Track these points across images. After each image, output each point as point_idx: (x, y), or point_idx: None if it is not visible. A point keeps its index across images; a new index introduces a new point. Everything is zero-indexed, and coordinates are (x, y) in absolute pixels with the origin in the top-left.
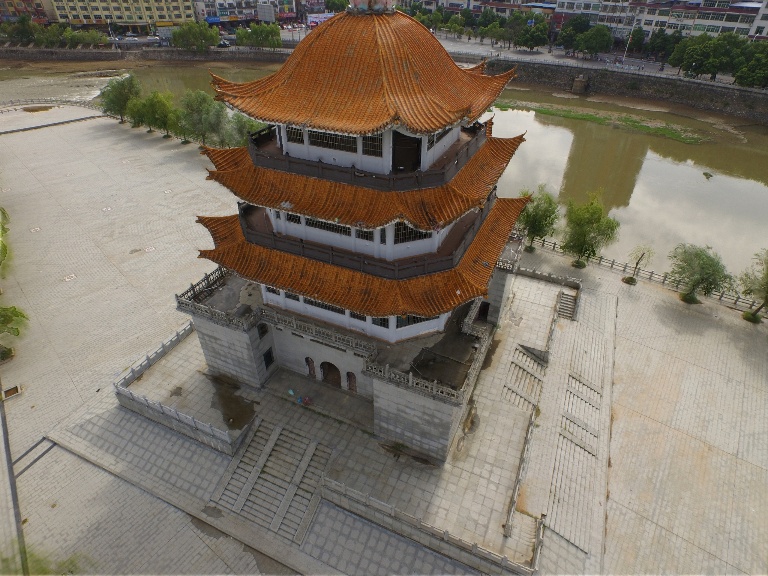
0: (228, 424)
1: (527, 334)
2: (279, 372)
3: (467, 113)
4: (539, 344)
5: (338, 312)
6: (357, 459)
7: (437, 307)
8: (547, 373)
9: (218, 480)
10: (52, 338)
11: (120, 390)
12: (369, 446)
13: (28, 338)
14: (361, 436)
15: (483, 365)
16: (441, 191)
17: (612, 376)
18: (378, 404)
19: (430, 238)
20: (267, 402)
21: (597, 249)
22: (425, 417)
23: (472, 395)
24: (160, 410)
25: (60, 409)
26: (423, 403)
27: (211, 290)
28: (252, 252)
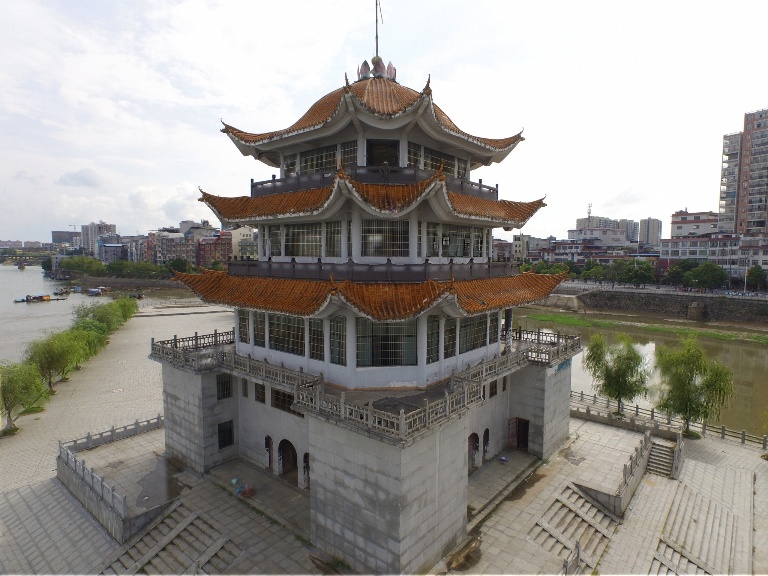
0: (139, 500)
1: (588, 474)
2: (236, 462)
3: (425, 90)
4: (606, 486)
5: (299, 354)
6: (267, 568)
7: (393, 313)
8: (620, 531)
9: (85, 574)
10: (60, 426)
11: (62, 452)
12: (294, 556)
13: (41, 424)
14: (291, 542)
15: (510, 496)
16: (410, 188)
17: (750, 565)
18: (314, 475)
19: (407, 257)
20: (201, 488)
21: (713, 415)
22: (367, 491)
23: (480, 525)
24: (82, 475)
25: (6, 479)
26: (364, 460)
27: (195, 350)
28: (228, 283)
